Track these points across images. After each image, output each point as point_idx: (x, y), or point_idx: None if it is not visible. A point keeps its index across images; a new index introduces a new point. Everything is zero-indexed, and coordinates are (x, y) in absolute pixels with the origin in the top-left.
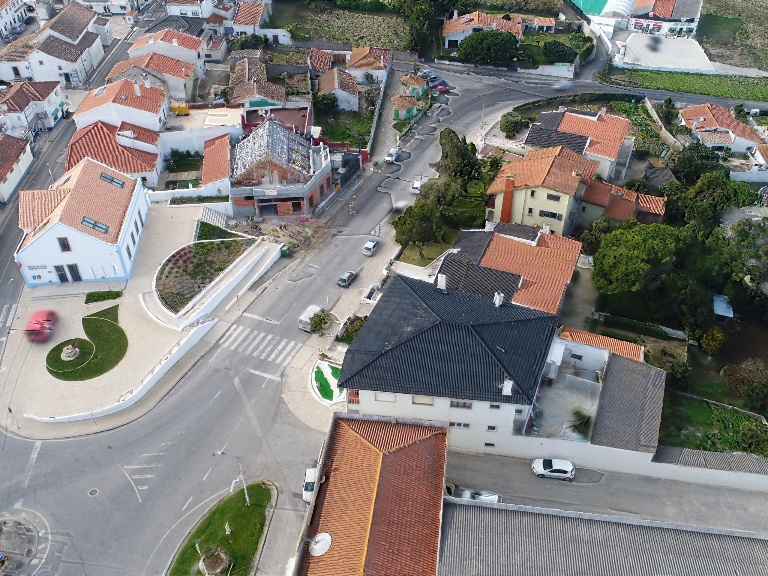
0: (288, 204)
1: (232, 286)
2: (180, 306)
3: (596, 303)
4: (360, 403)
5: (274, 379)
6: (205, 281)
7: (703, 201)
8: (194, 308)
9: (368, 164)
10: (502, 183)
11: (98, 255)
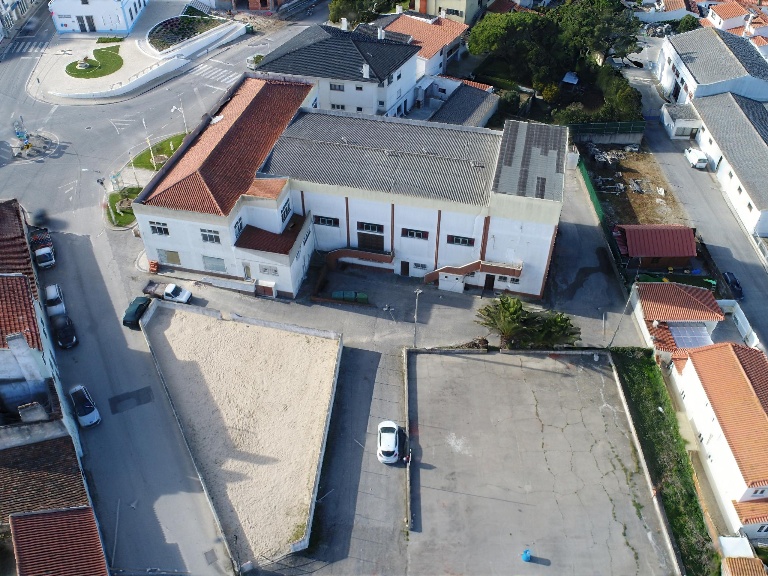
0: None
1: (205, 44)
2: (164, 48)
3: (474, 70)
4: None
5: (222, 90)
6: None
7: (574, 6)
8: (174, 50)
9: None
10: None
11: (107, 8)
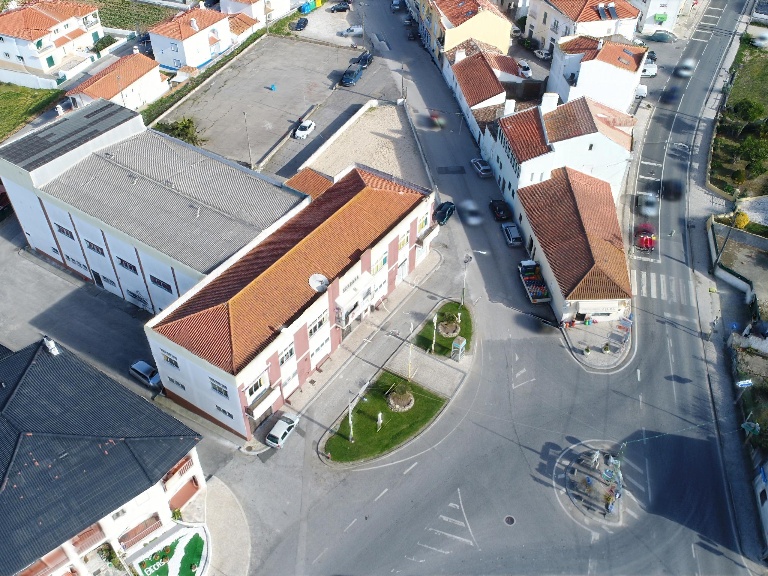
0: None
1: None
2: None
3: None
4: None
5: None
6: None
7: None
8: None
9: None
10: None
11: None
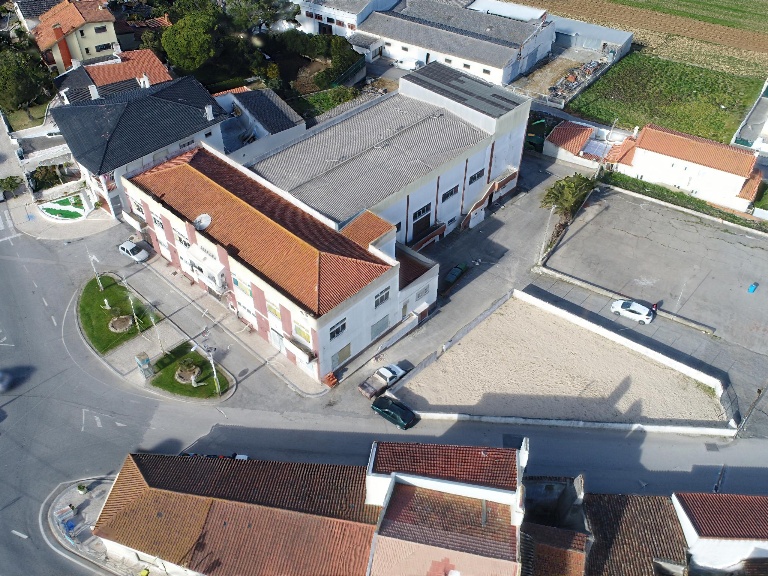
0: None
1: None
2: None
3: None
4: (117, 187)
5: (15, 237)
6: None
7: None
8: None
9: None
10: (48, 39)
11: None
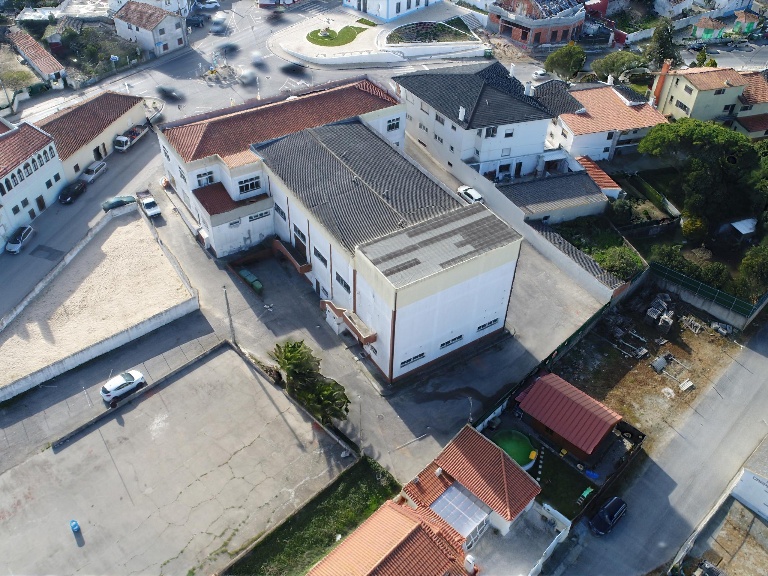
0: (520, 31)
1: (435, 52)
2: (394, 42)
3: (644, 170)
4: None
5: None
6: (422, 40)
7: None
8: (400, 47)
9: (622, 46)
10: None
11: None
